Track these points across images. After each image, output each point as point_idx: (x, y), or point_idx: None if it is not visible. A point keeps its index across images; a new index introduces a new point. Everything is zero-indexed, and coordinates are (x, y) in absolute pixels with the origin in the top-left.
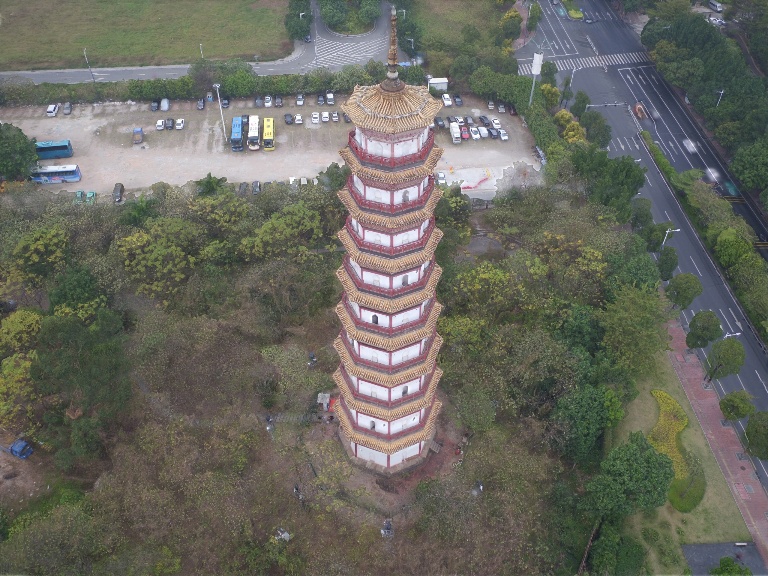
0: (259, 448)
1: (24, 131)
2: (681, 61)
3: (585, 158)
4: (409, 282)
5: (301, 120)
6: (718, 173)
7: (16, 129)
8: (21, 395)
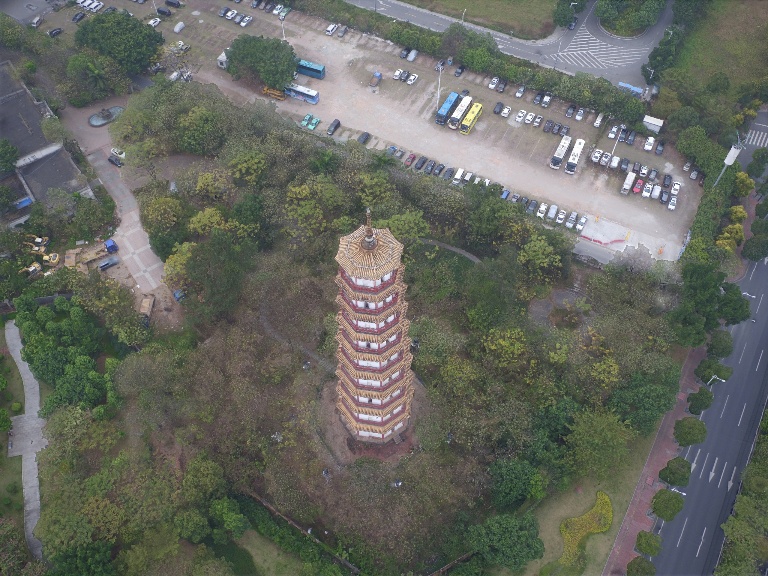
0: (296, 375)
1: (304, 42)
2: None
3: (697, 273)
4: (371, 347)
5: (507, 114)
6: None
7: (290, 48)
8: (180, 273)
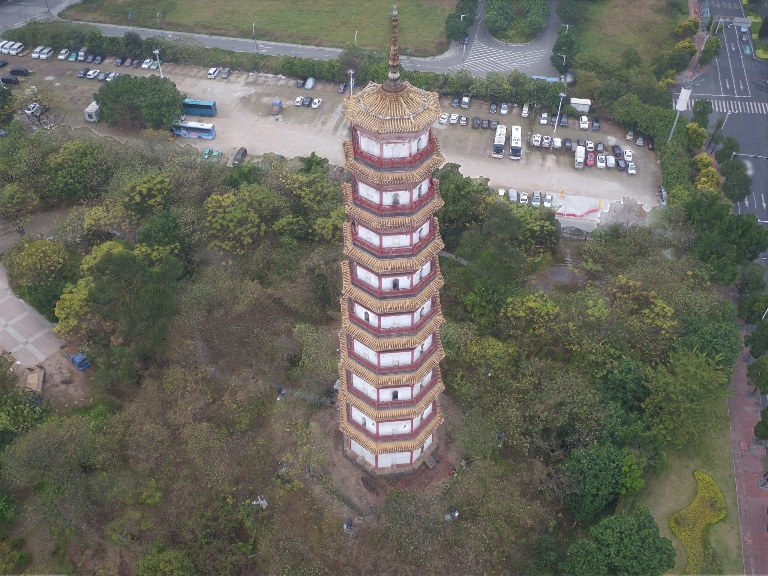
0: (268, 415)
1: (184, 87)
2: None
3: (701, 207)
4: (400, 287)
5: None
6: None
7: (171, 84)
8: (79, 313)
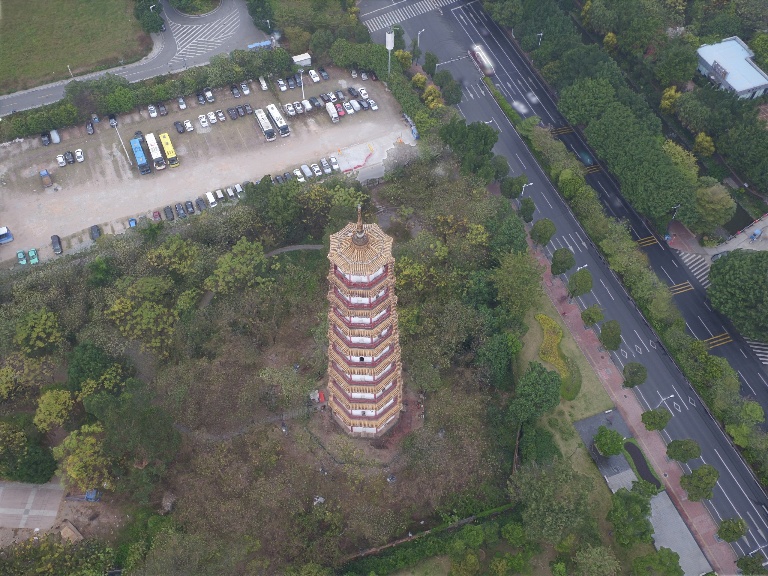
0: None
1: None
2: (503, 0)
3: (450, 131)
4: (382, 334)
5: (192, 127)
6: (549, 107)
7: None
8: (97, 465)
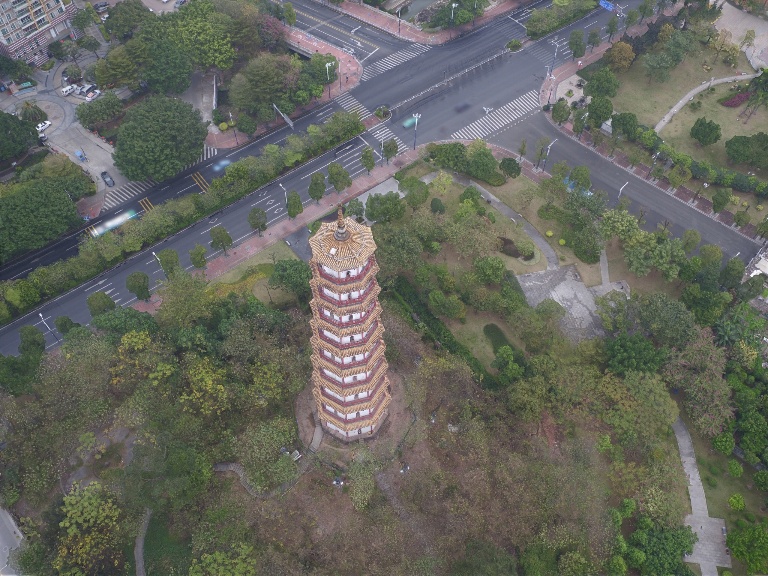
0: None
1: None
2: None
3: None
4: None
5: None
6: None
7: None
8: None
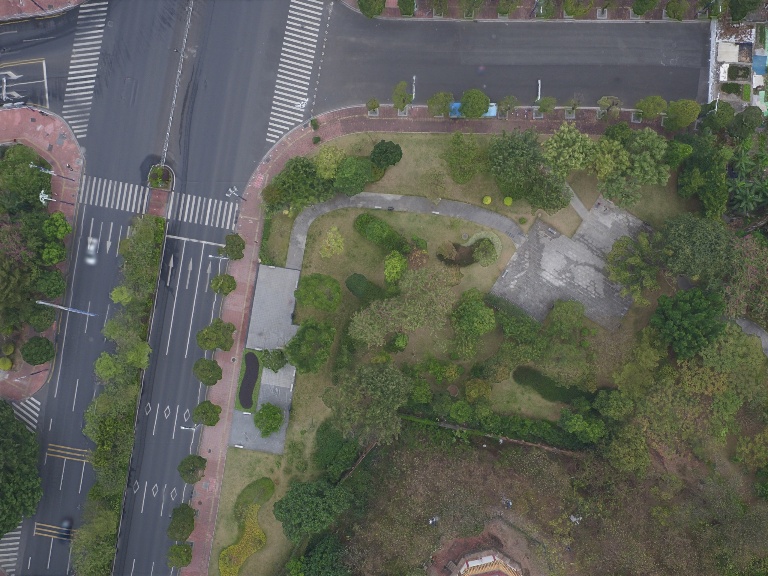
0: None
1: None
2: None
3: None
4: None
5: None
6: None
7: None
8: None
